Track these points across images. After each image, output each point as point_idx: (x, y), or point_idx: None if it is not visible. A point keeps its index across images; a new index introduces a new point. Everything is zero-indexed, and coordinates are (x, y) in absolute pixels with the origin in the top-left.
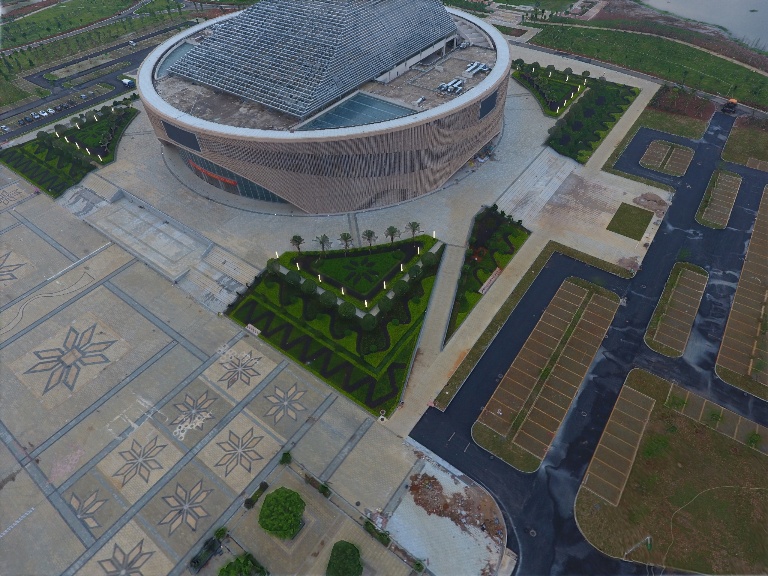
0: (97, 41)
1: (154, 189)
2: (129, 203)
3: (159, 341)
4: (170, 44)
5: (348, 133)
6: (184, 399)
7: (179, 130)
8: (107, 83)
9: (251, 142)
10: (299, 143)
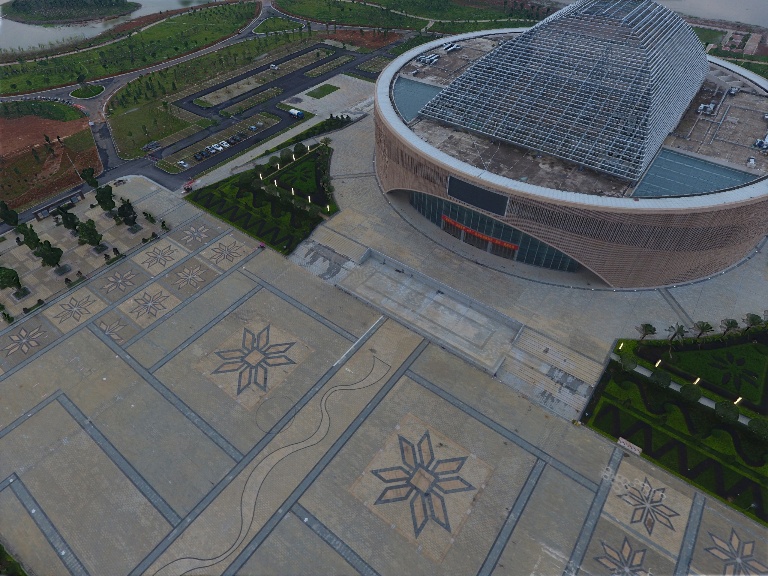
0: (232, 63)
1: (407, 249)
2: (381, 265)
3: (521, 459)
4: (388, 79)
5: (708, 204)
6: (603, 550)
7: (482, 190)
8: (269, 112)
9: (591, 211)
10: (653, 215)
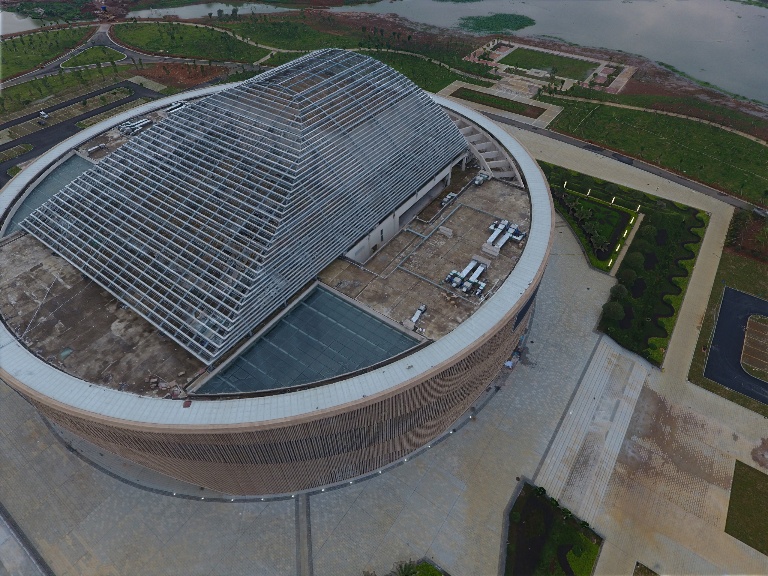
0: (0, 109)
1: None
2: None
3: None
4: (48, 161)
5: (288, 413)
6: None
7: None
8: None
9: (109, 426)
10: (197, 434)
